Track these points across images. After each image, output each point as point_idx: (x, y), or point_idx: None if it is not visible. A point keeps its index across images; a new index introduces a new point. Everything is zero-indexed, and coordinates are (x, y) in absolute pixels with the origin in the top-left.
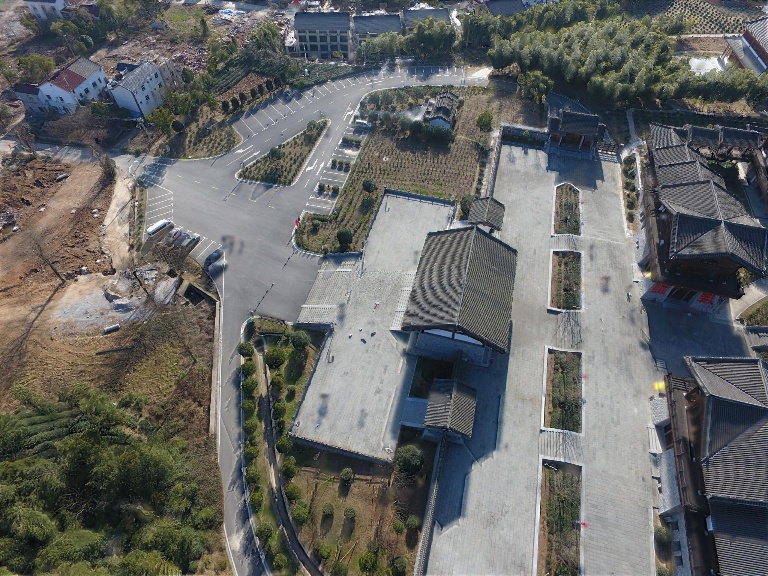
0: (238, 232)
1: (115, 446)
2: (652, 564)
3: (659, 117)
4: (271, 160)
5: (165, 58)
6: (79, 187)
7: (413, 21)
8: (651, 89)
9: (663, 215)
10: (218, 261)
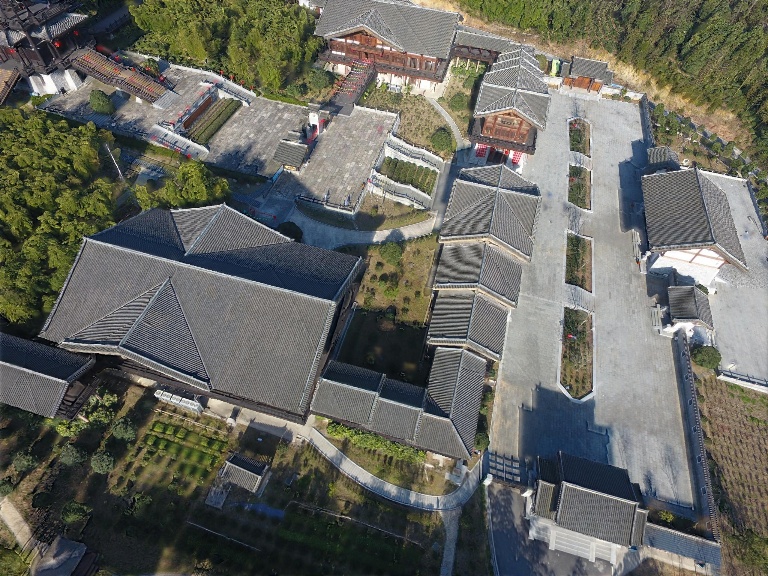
0: None
1: None
2: None
3: None
4: None
5: None
6: None
7: None
8: None
9: None
10: None
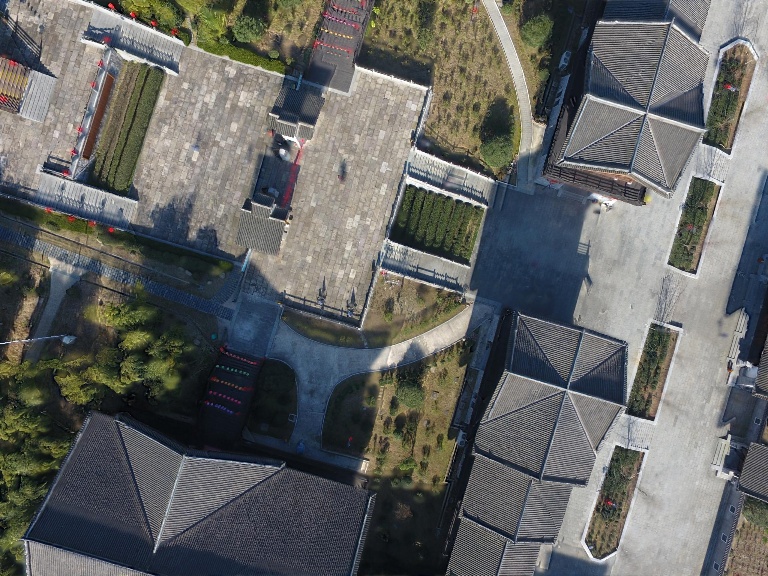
0: None
1: None
2: None
3: None
4: None
5: None
6: None
7: None
8: None
9: None
10: None
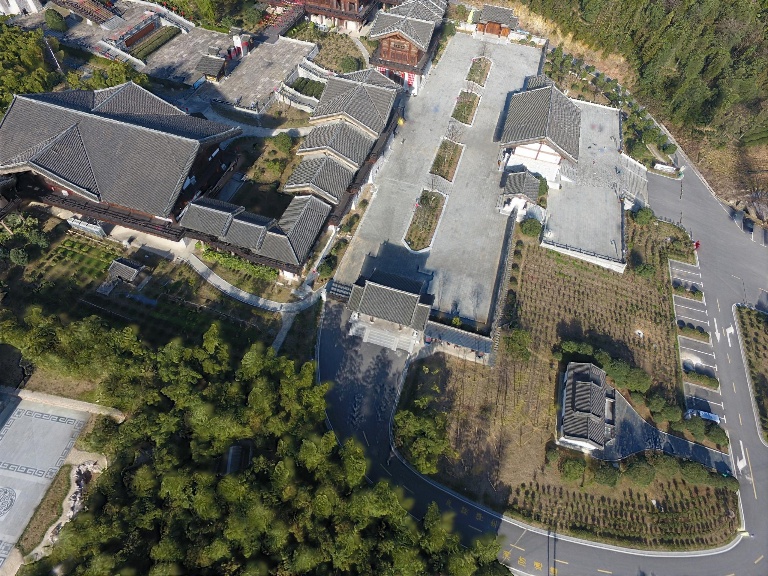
0: (748, 252)
1: (708, 107)
2: None
3: None
4: None
5: None
6: None
7: None
8: None
9: None
10: None
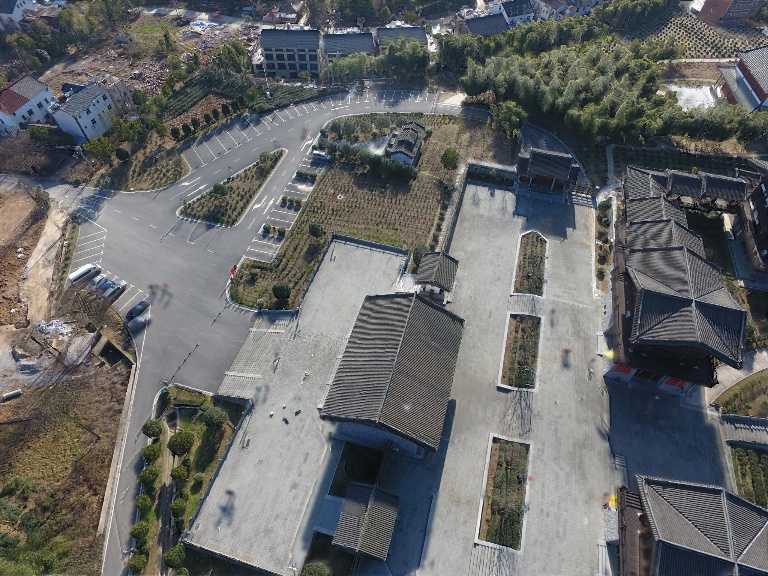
0: (169, 280)
1: None
2: None
3: (641, 155)
4: (216, 196)
5: (117, 78)
6: (8, 221)
7: (387, 40)
8: (632, 125)
9: (631, 281)
10: (141, 315)
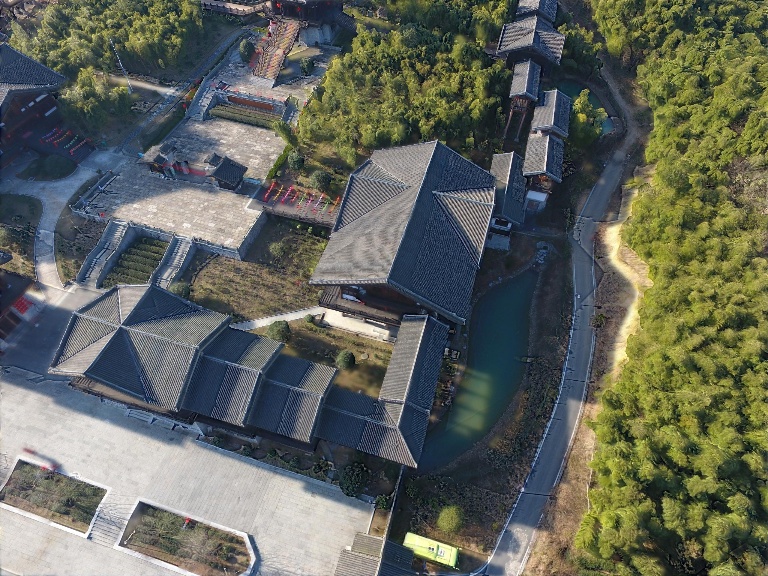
0: None
1: None
2: (240, 458)
3: None
4: None
5: None
6: None
7: None
8: None
9: None
10: None
